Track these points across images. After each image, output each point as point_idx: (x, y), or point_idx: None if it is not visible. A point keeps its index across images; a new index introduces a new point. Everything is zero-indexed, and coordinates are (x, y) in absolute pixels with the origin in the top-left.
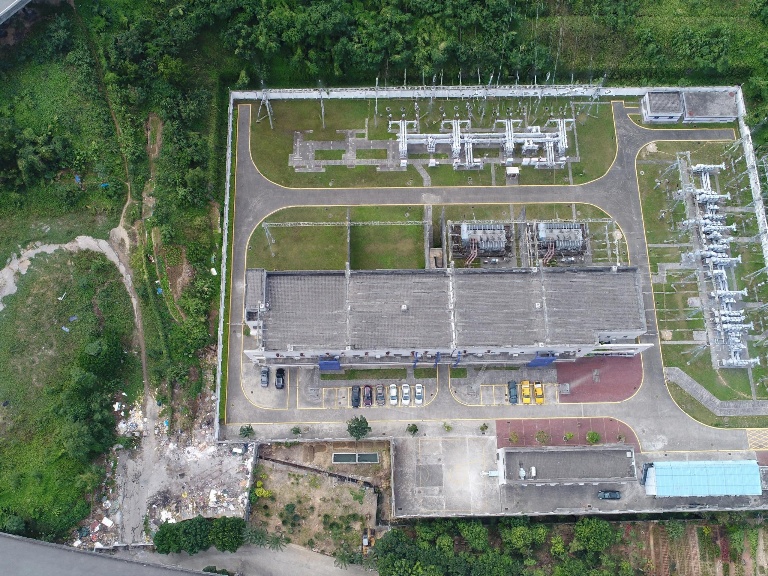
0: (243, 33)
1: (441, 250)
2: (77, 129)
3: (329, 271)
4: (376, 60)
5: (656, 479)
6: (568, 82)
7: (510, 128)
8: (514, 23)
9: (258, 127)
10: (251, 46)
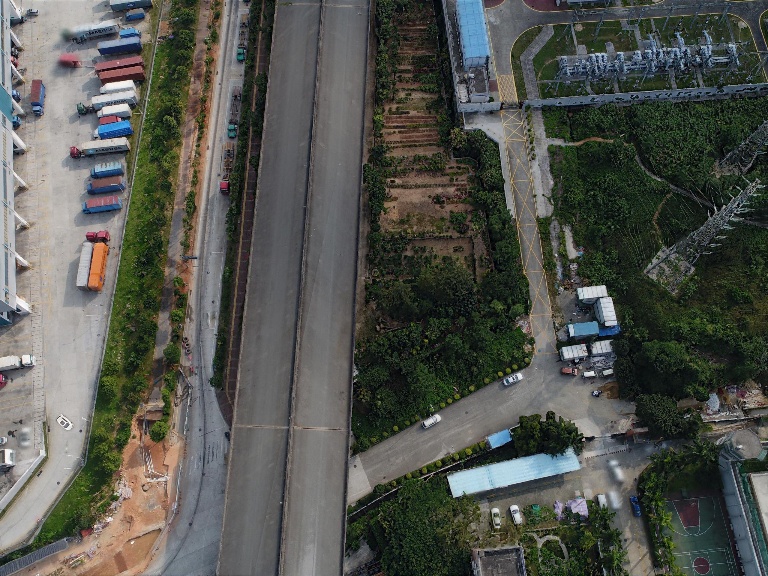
0: None
1: None
2: None
3: None
4: None
5: None
6: None
7: None
8: None
9: None
10: None
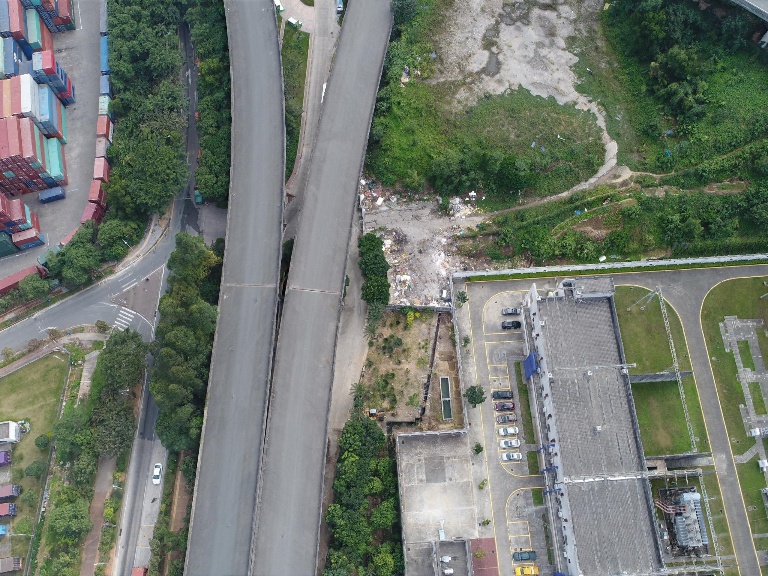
0: None
1: None
2: (717, 121)
3: None
4: None
5: None
6: None
7: None
8: None
9: (759, 284)
10: None
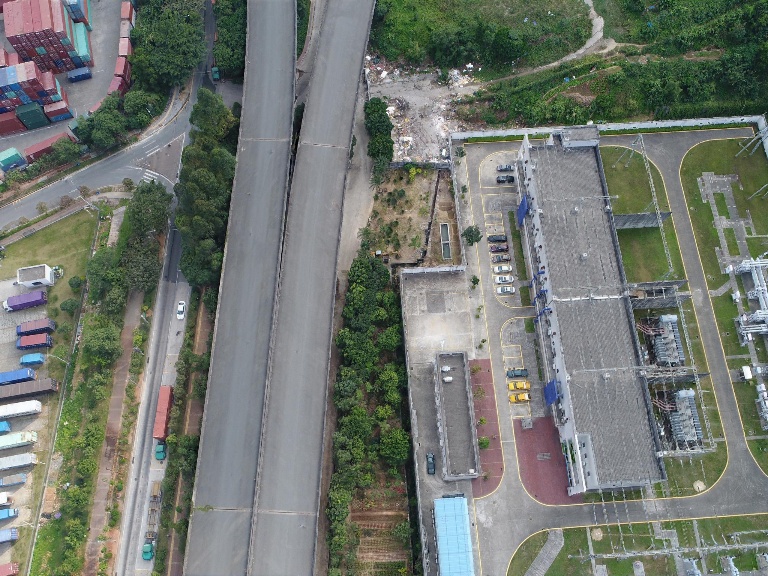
0: None
1: None
2: None
3: None
4: None
5: (451, 498)
6: None
7: None
8: None
9: (734, 144)
10: None
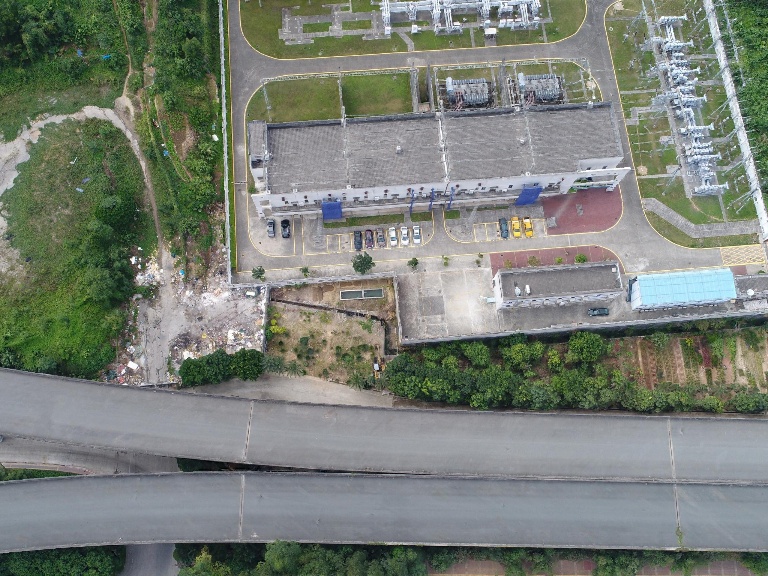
0: None
1: (428, 105)
2: (77, 3)
3: (326, 121)
4: None
5: (640, 290)
6: None
7: None
8: None
9: (247, 6)
10: None
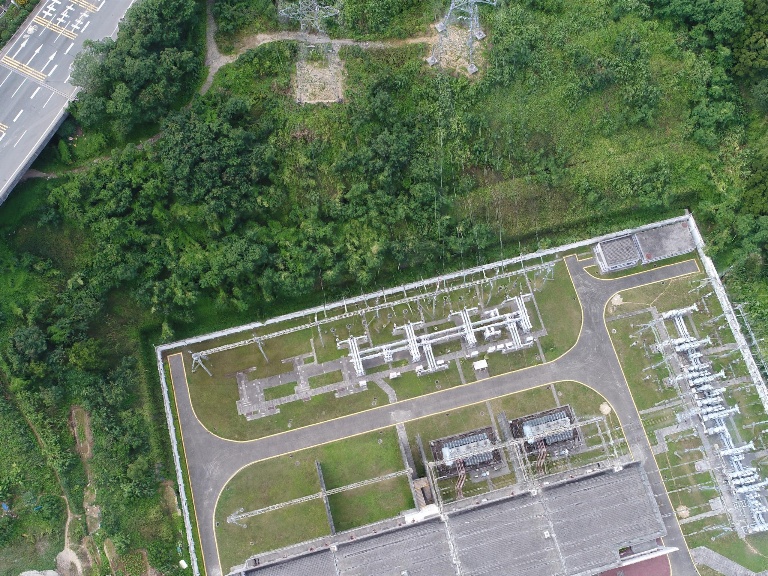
0: (156, 292)
1: (426, 479)
2: None
3: (313, 552)
4: (308, 284)
5: None
6: (514, 246)
7: (467, 319)
8: (445, 205)
9: (195, 378)
10: (168, 299)
